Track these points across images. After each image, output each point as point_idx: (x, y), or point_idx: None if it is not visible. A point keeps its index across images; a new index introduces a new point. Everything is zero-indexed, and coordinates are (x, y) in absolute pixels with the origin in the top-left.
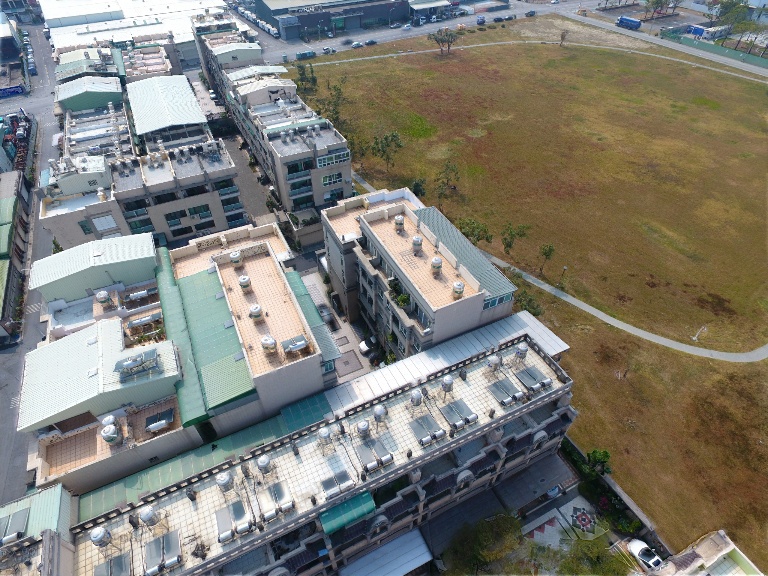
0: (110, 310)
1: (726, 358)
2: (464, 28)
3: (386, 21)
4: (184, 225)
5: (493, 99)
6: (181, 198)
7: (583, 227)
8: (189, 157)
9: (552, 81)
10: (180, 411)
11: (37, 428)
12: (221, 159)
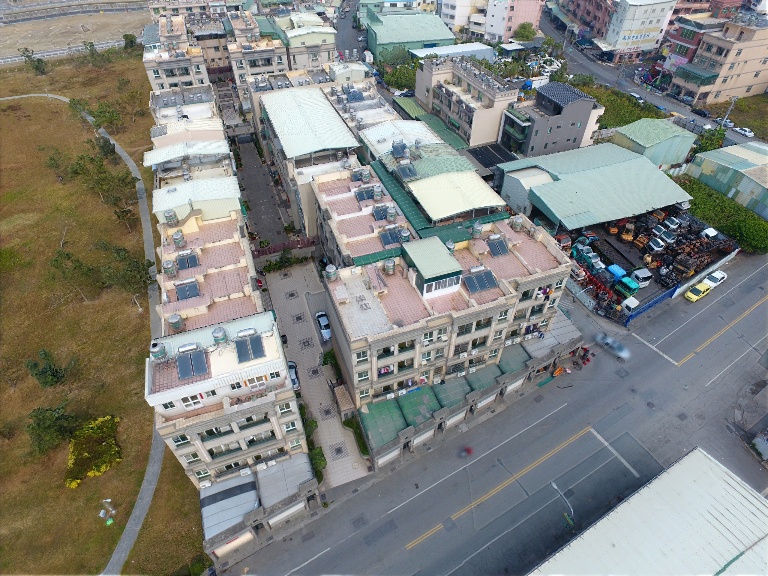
0: None
1: (49, 94)
2: None
3: None
4: None
5: None
6: None
7: (7, 144)
8: None
9: None
10: None
11: None
12: None
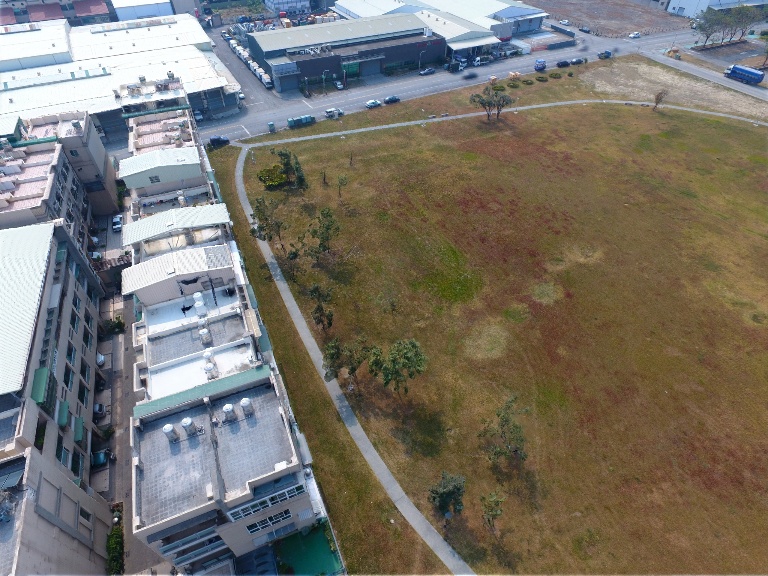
0: None
1: None
2: (518, 77)
3: (415, 64)
4: None
5: (567, 214)
6: None
7: None
8: None
9: (652, 178)
10: None
11: None
12: (13, 515)
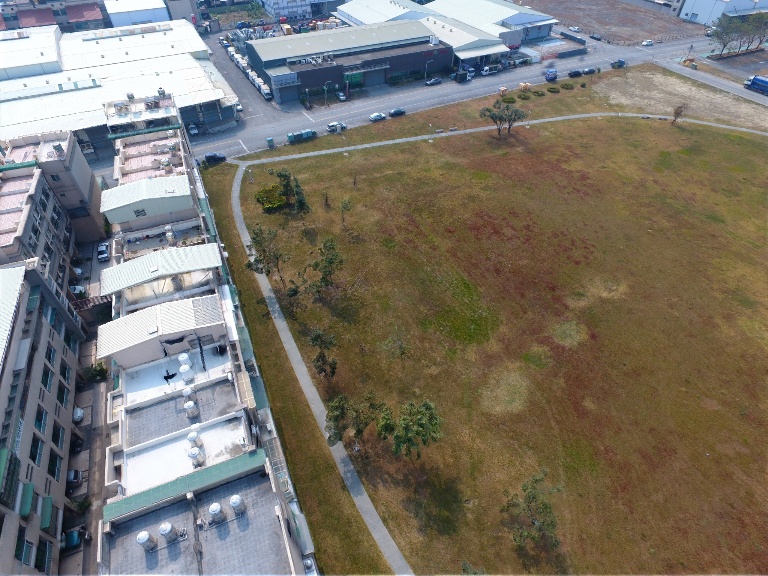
0: None
1: None
2: (529, 88)
3: (420, 74)
4: None
5: (587, 241)
6: None
7: None
8: None
9: (676, 200)
10: None
11: None
12: None
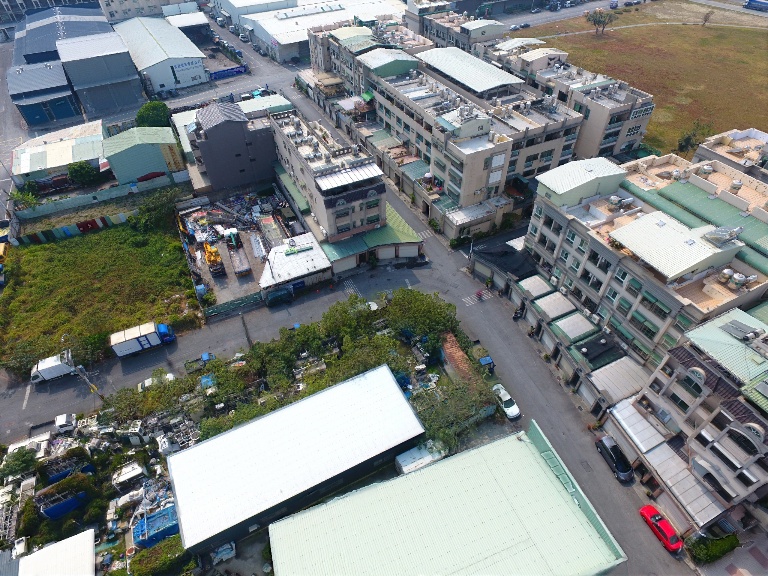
0: (616, 211)
1: None
2: (602, 12)
3: (525, 7)
4: (533, 167)
5: (675, 72)
6: (542, 142)
7: None
8: (529, 110)
9: (718, 56)
10: (761, 269)
11: (674, 278)
12: (556, 111)
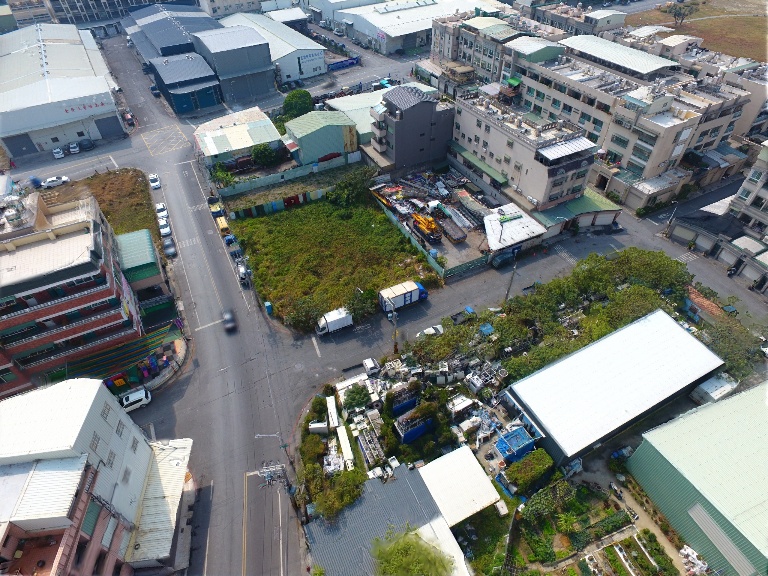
0: None
1: None
2: None
3: (596, 1)
4: (702, 142)
5: None
6: (717, 118)
7: None
8: (694, 89)
9: None
10: None
11: None
12: (719, 91)
